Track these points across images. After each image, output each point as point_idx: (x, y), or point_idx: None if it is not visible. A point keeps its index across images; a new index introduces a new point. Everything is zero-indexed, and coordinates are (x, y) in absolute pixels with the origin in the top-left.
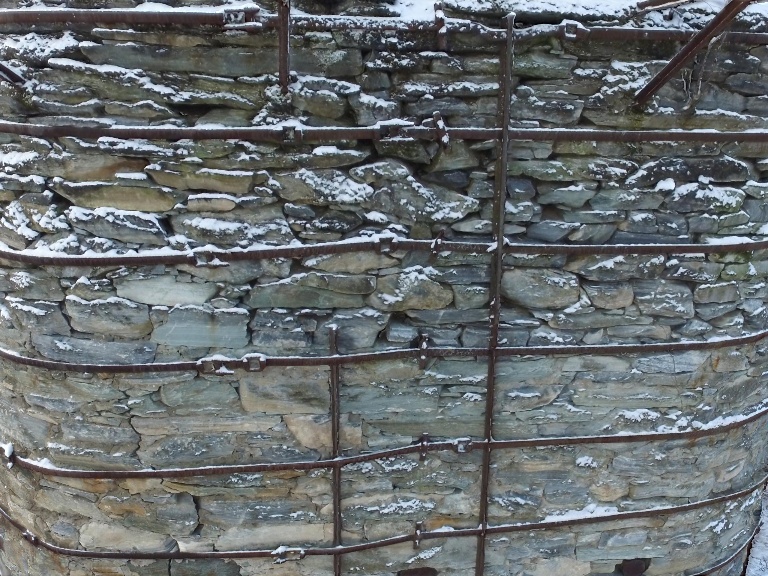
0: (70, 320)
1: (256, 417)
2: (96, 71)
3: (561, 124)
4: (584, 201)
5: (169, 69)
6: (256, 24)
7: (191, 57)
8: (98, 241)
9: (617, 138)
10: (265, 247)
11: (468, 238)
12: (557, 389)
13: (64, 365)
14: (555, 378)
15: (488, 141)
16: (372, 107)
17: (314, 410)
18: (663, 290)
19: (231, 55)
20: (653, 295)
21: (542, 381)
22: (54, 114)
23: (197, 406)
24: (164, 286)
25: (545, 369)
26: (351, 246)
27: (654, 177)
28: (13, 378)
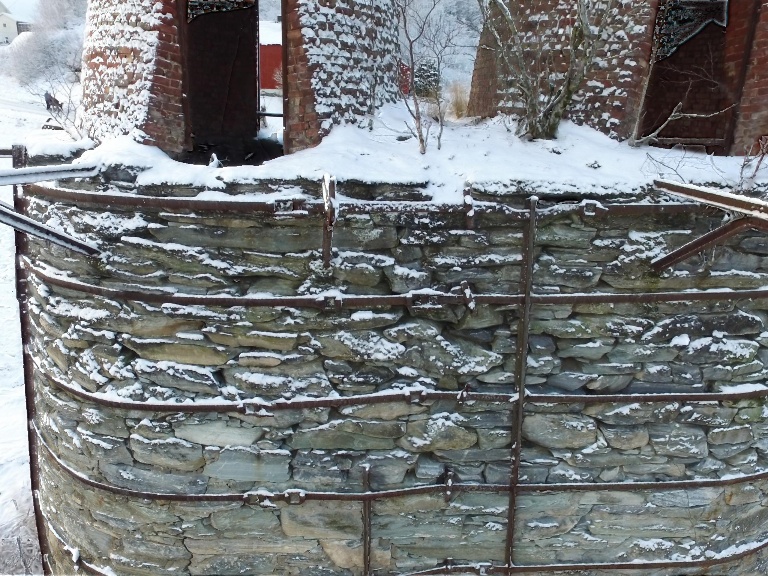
0: (133, 453)
1: (295, 541)
2: (162, 249)
3: (580, 288)
4: (602, 354)
5: (225, 246)
6: (303, 213)
7: (245, 237)
8: (160, 390)
9: (634, 300)
10: (306, 399)
11: (492, 387)
12: (574, 520)
13: (127, 491)
14: (573, 510)
15: (511, 305)
16: (405, 278)
17: (348, 536)
18: (677, 433)
19: (280, 235)
20: (667, 438)
21: (560, 512)
22: (124, 281)
23: (243, 530)
24: (216, 430)
25: (563, 502)
26: (384, 398)
27: (669, 333)
28: (81, 494)
